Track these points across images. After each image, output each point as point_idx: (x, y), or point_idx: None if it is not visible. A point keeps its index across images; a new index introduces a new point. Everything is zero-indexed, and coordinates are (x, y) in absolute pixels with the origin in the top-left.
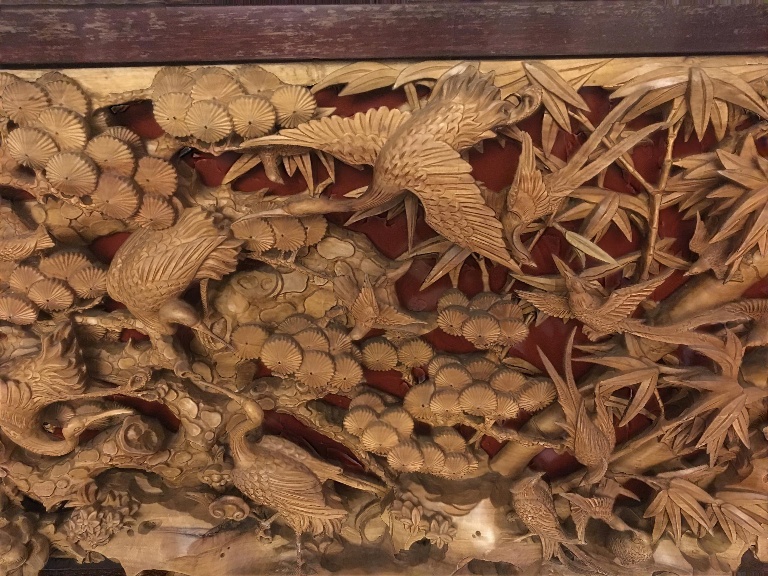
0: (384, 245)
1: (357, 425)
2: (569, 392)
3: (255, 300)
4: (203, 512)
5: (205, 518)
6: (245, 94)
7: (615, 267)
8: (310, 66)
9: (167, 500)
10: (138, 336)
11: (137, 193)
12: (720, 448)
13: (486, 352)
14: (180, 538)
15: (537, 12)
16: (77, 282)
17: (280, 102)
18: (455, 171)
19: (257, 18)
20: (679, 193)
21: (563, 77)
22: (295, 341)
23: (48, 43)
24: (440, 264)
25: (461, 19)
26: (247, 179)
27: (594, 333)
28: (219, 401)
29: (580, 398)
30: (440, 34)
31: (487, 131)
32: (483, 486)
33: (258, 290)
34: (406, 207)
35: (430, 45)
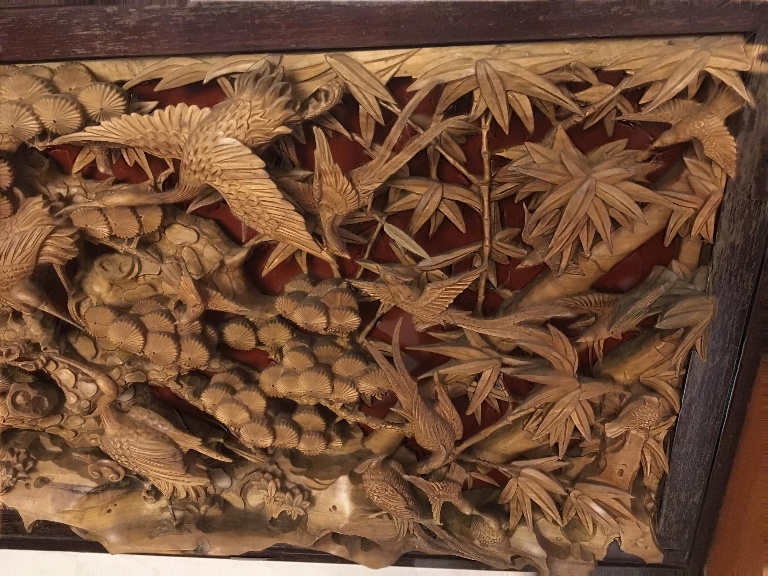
0: (236, 231)
1: (211, 401)
2: (402, 380)
3: (116, 281)
4: None
5: (91, 477)
6: (52, 93)
7: (454, 257)
8: (130, 62)
9: (61, 459)
10: None
11: None
12: (568, 441)
13: (337, 336)
14: (67, 494)
15: (331, 4)
16: None
17: (87, 100)
18: (248, 167)
19: (65, 18)
20: (512, 184)
21: (369, 69)
22: (140, 322)
23: None
24: (275, 252)
25: (257, 14)
26: None
27: (420, 324)
28: None
29: (415, 386)
30: (239, 29)
31: (280, 127)
32: (348, 463)
33: (116, 272)
34: None
35: (231, 40)
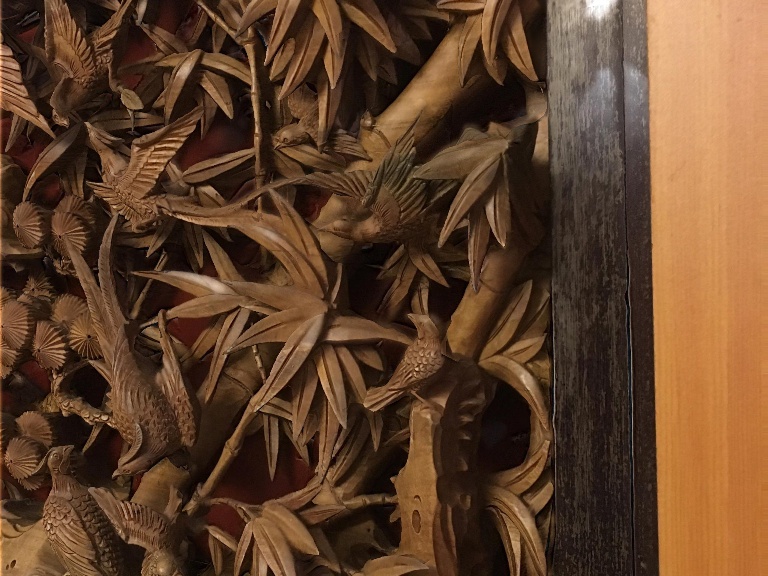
0: None
1: None
2: None
3: None
4: None
5: None
6: None
7: (226, 162)
8: None
9: None
10: None
11: None
12: (332, 445)
13: None
14: None
15: None
16: None
17: None
18: None
19: None
20: None
21: None
22: None
23: None
24: None
25: None
26: None
27: (138, 221)
28: None
29: None
30: None
31: None
32: None
33: None
34: None
35: None
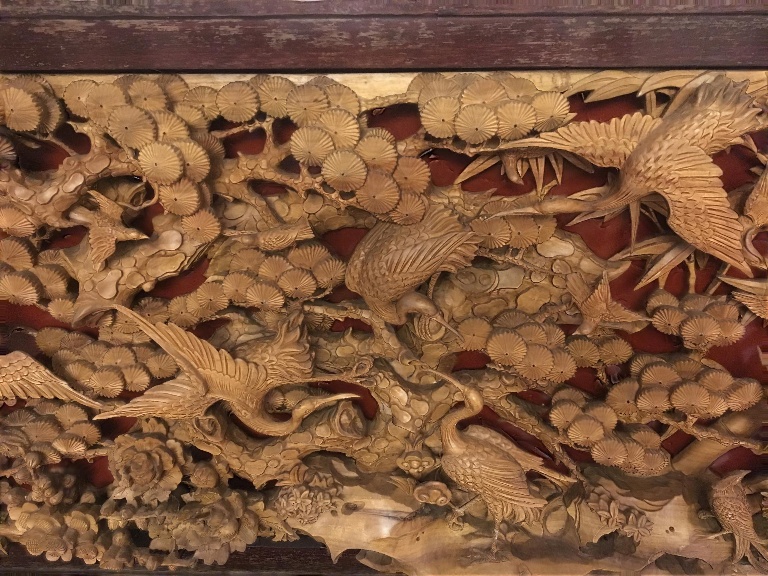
0: (595, 246)
1: (564, 418)
2: None
3: (472, 295)
4: (402, 496)
5: (405, 502)
6: (510, 99)
7: None
8: (556, 74)
9: (367, 484)
10: (357, 326)
11: (399, 190)
12: None
13: (689, 352)
14: (383, 520)
15: None
16: (321, 272)
17: (540, 107)
18: (706, 175)
19: (520, 28)
20: None
21: None
22: None
23: (323, 50)
24: (659, 265)
25: (713, 31)
26: (475, 180)
27: None
28: (423, 391)
29: None
30: (691, 45)
31: (737, 137)
32: (672, 484)
33: (477, 285)
34: (631, 209)
35: (680, 55)
